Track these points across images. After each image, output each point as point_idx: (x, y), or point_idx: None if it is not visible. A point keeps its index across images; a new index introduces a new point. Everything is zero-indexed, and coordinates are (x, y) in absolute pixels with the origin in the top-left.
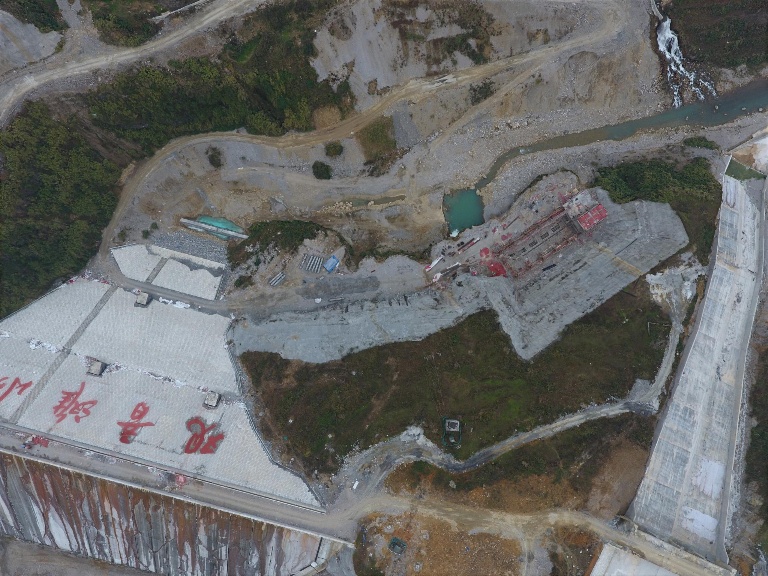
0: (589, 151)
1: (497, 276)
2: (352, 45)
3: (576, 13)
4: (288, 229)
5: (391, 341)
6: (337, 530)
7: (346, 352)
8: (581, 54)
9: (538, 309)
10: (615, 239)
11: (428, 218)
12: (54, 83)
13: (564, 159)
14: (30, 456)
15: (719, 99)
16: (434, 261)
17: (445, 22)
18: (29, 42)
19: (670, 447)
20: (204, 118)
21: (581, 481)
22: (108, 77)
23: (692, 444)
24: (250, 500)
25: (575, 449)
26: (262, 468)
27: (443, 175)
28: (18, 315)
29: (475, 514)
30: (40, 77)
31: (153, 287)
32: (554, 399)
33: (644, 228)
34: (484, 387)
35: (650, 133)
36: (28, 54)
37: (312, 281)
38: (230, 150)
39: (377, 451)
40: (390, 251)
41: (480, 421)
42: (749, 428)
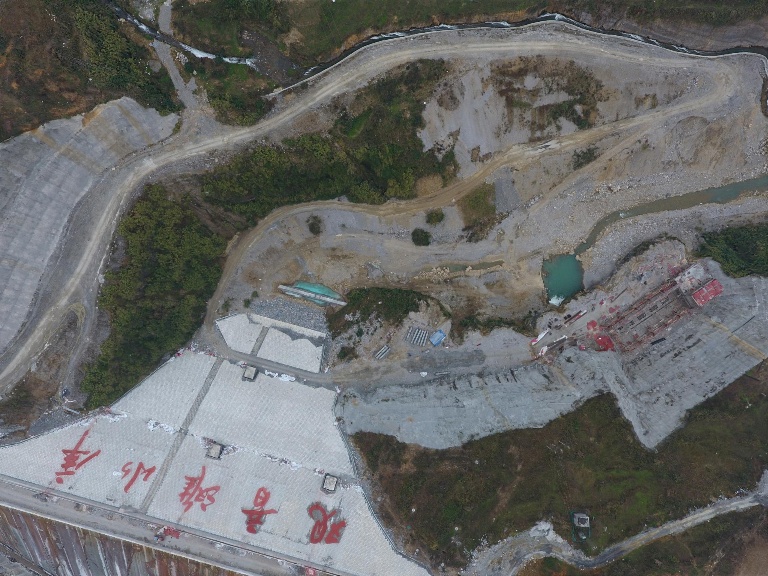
0: (692, 215)
1: (606, 351)
2: (459, 114)
3: (687, 78)
4: (390, 299)
5: (512, 428)
6: None
7: (466, 439)
8: (689, 118)
9: (652, 388)
10: (729, 314)
11: (527, 284)
12: (172, 165)
13: (666, 223)
14: (162, 548)
15: None
16: (540, 334)
17: (553, 89)
18: (149, 125)
19: None
20: (310, 191)
21: None
22: (225, 158)
23: None
24: None
25: (708, 547)
26: (387, 558)
27: (542, 240)
28: (133, 393)
29: None
30: (159, 159)
31: (258, 360)
32: (682, 492)
33: (762, 305)
34: (609, 478)
35: (755, 196)
36: (147, 137)
37: (417, 354)
38: (330, 218)
39: (506, 546)
40: (490, 319)
41: (608, 515)
42: None
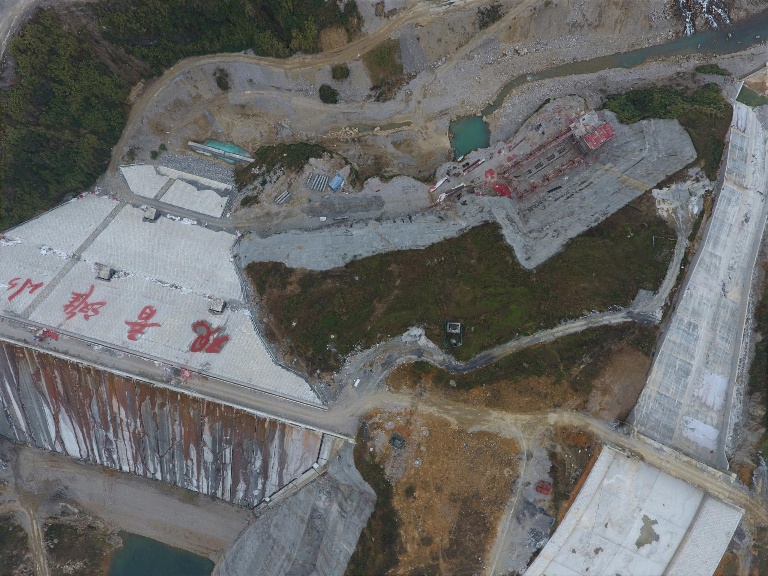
0: (598, 78)
1: (502, 196)
2: None
3: None
4: (294, 150)
5: (394, 249)
6: (338, 426)
7: (349, 259)
8: None
9: (542, 227)
10: (622, 159)
11: (434, 144)
12: None
13: (572, 86)
14: (41, 348)
15: (732, 27)
16: (439, 181)
17: None
18: None
19: (672, 359)
20: (212, 35)
21: (581, 383)
22: None
23: (695, 357)
24: (253, 395)
25: (576, 352)
26: (265, 368)
27: (450, 101)
28: (30, 224)
29: (475, 412)
30: None
31: (161, 204)
32: (556, 306)
33: (652, 147)
34: (486, 294)
35: (661, 61)
36: None
37: (317, 200)
38: (237, 72)
39: (379, 351)
40: (395, 175)
41: (481, 325)
42: (753, 342)
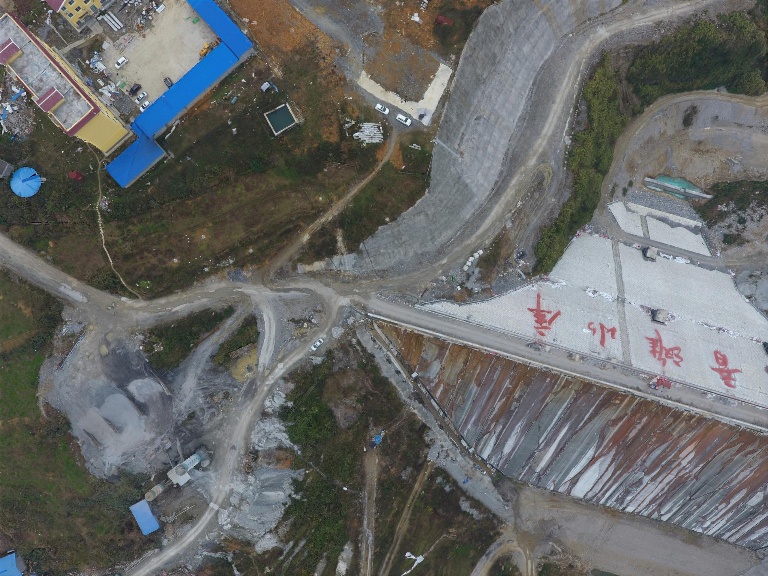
0: None
1: None
2: None
3: None
4: None
5: None
6: None
7: None
8: None
9: None
10: None
11: None
12: (624, 34)
13: None
14: None
15: None
16: None
17: None
18: None
19: None
20: None
21: None
22: (670, 29)
23: None
24: None
25: None
26: None
27: None
28: (560, 265)
29: None
30: (610, 28)
31: (652, 242)
32: None
33: None
34: None
35: None
36: (603, 5)
37: None
38: (707, 109)
39: None
40: None
41: None
42: None
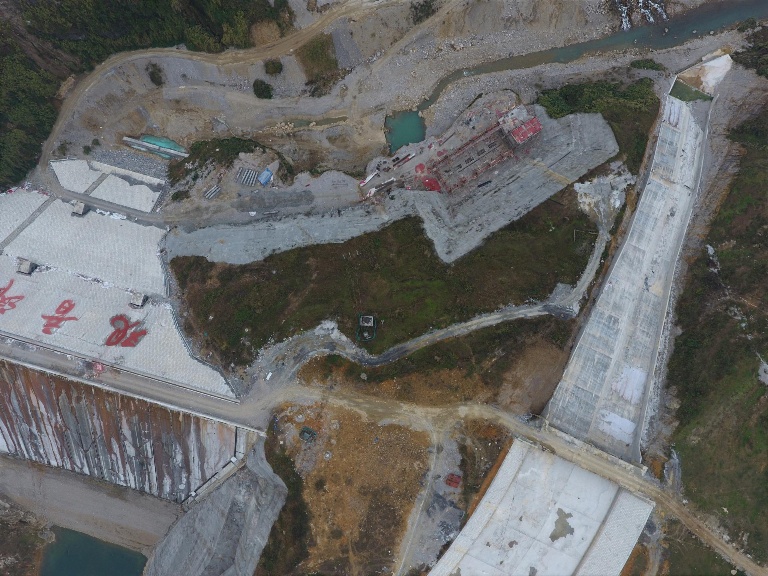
0: (534, 73)
1: (431, 190)
2: None
3: None
4: (226, 145)
5: (313, 243)
6: (250, 420)
7: (268, 253)
8: None
9: (468, 221)
10: (550, 154)
11: (369, 139)
12: None
13: (508, 81)
14: None
15: (669, 22)
16: (369, 176)
17: None
18: None
19: (591, 353)
20: (140, 30)
21: (492, 376)
22: None
23: (614, 351)
24: (166, 389)
25: (488, 345)
26: (181, 362)
27: (385, 96)
28: None
29: (385, 406)
30: None
31: (91, 199)
32: (472, 299)
33: (578, 141)
34: (403, 288)
35: (597, 56)
36: None
37: (247, 194)
38: (170, 67)
39: (291, 344)
40: None
41: (396, 318)
42: (673, 336)
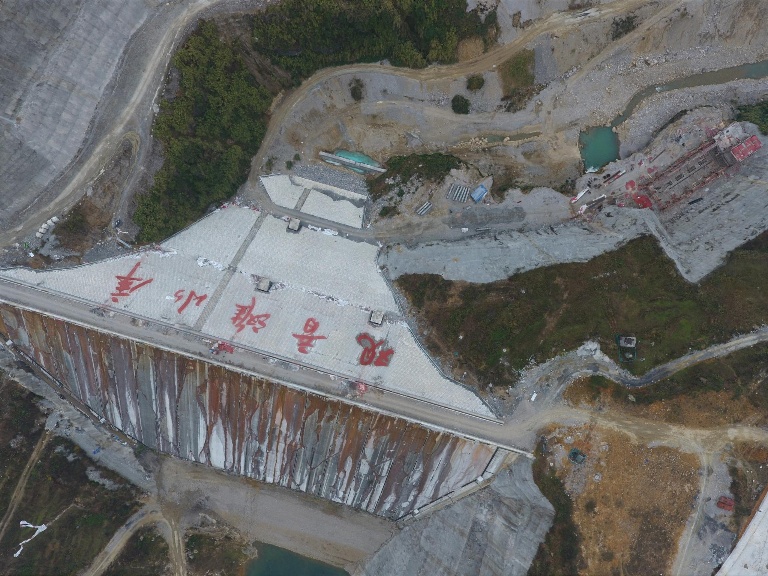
0: (727, 89)
1: None
2: None
3: None
4: (431, 161)
5: (557, 262)
6: (515, 441)
7: (512, 272)
8: None
9: (691, 239)
10: (767, 171)
11: (564, 155)
12: (225, 3)
13: (702, 97)
14: (217, 361)
15: None
16: (580, 193)
17: None
18: None
19: None
20: (356, 46)
21: (760, 398)
22: None
23: None
24: (429, 409)
25: (752, 367)
26: (435, 381)
27: (580, 112)
28: (182, 235)
29: (654, 427)
30: None
31: (302, 214)
32: (725, 320)
33: None
34: (653, 308)
35: None
36: None
37: (458, 211)
38: (372, 82)
39: (554, 365)
40: (528, 186)
41: (654, 339)
42: None
